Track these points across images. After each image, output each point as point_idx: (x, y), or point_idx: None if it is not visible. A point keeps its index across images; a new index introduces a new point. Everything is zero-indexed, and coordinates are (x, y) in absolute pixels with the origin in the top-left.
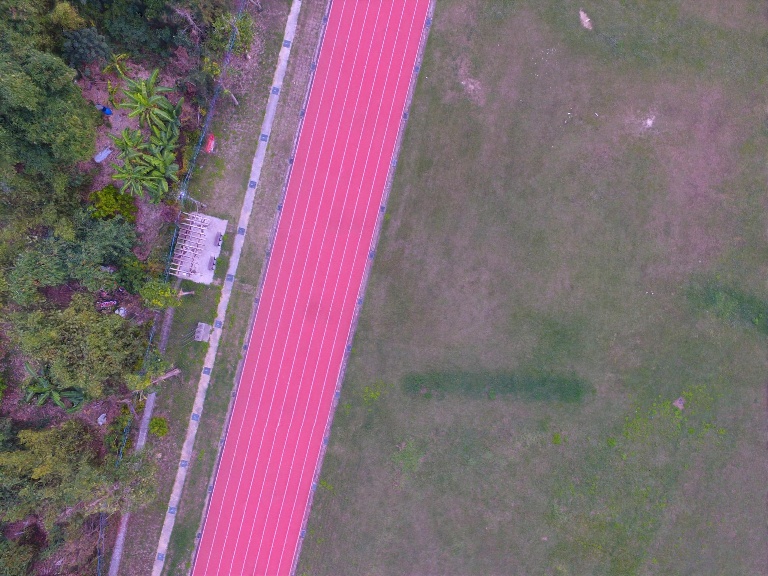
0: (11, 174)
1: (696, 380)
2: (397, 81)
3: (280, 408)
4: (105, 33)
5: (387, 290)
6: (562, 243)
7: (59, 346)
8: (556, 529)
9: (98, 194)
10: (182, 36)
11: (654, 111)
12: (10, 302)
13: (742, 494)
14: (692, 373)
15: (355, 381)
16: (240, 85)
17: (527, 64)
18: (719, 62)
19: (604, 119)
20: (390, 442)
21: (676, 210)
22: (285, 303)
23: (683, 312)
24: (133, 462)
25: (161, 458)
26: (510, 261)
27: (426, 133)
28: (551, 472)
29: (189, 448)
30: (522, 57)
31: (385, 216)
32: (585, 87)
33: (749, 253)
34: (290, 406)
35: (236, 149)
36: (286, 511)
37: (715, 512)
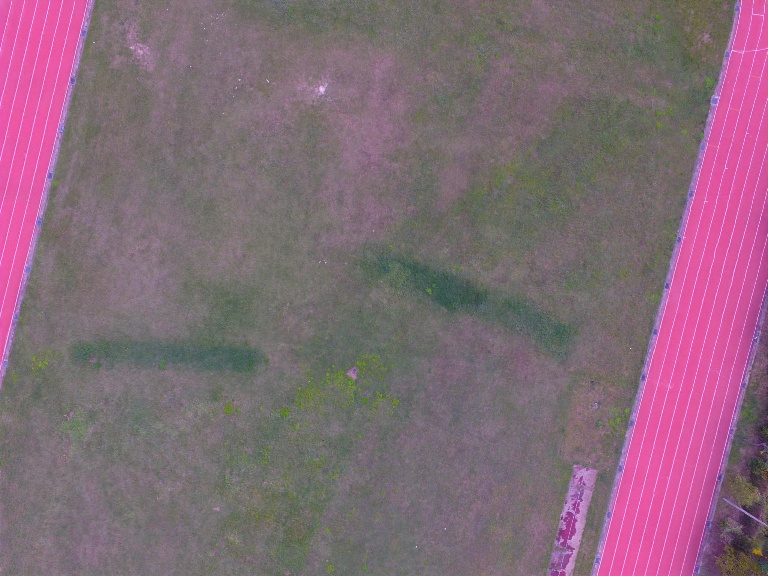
0: None
1: (370, 350)
2: (63, 45)
3: None
4: None
5: (55, 258)
6: (234, 211)
7: None
8: (228, 499)
9: None
10: None
11: (326, 78)
12: None
13: (416, 464)
14: (366, 343)
15: (23, 350)
16: None
17: (196, 29)
18: (392, 29)
19: (275, 86)
20: (58, 412)
21: (349, 179)
22: None
23: (356, 282)
24: None
25: None
26: (181, 229)
27: (94, 99)
28: (223, 442)
29: None
30: (191, 22)
31: (52, 183)
32: (256, 53)
33: (423, 222)
34: None
35: None
36: None
37: (389, 482)
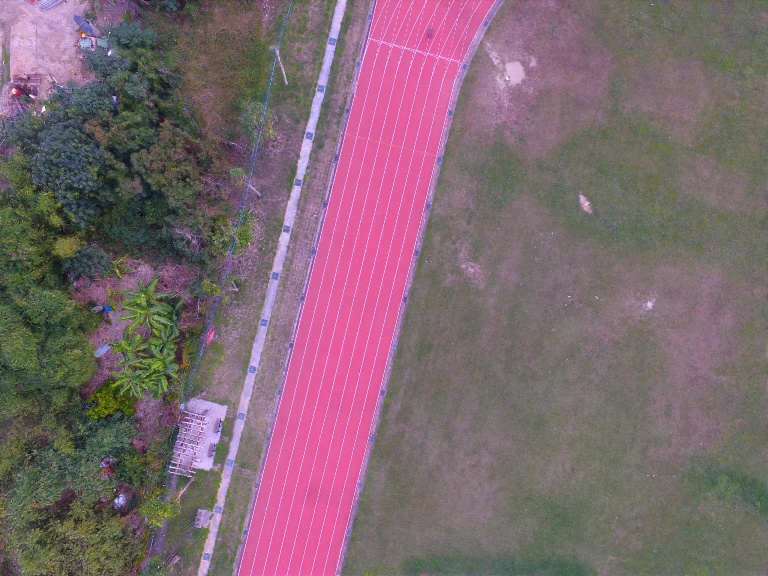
0: (10, 397)
1: (698, 563)
2: (397, 265)
3: None
4: (105, 234)
5: (387, 474)
6: (563, 426)
7: (58, 558)
8: None
9: (97, 396)
10: (182, 246)
11: (654, 294)
12: None
13: None
14: (694, 556)
15: (355, 565)
16: (240, 271)
17: (527, 248)
18: (719, 245)
19: (604, 302)
20: None
21: (677, 392)
22: (285, 488)
23: (684, 495)
24: None
25: None
26: (511, 444)
27: (426, 317)
28: None
29: None
30: (522, 241)
31: (385, 400)
32: (585, 270)
33: (750, 435)
34: None
35: (236, 334)
36: None
37: None
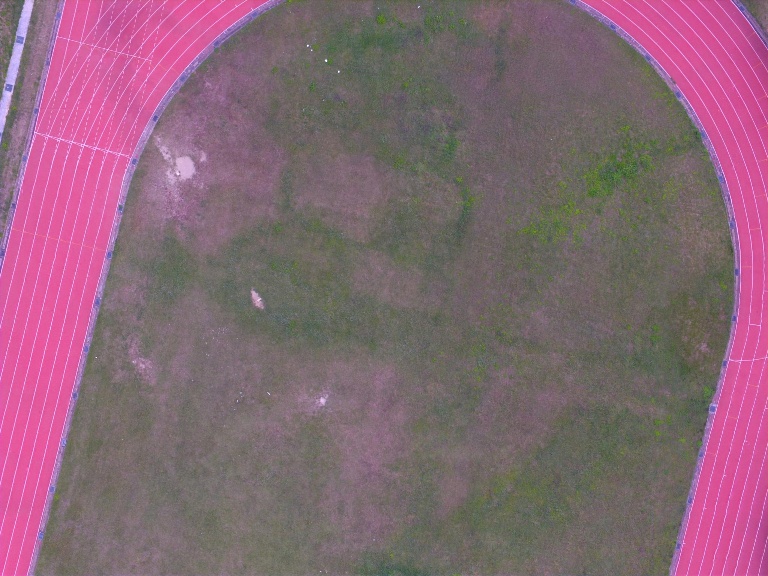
0: None
1: None
2: (66, 361)
3: None
4: None
5: (56, 571)
6: (235, 522)
7: None
8: None
9: None
10: None
11: (327, 390)
12: None
13: None
14: None
15: None
16: None
17: (198, 344)
18: (392, 341)
19: (276, 398)
20: None
21: (350, 488)
22: None
23: None
24: None
25: None
26: (182, 541)
27: (96, 413)
28: None
29: None
30: (193, 337)
31: (54, 497)
32: (257, 366)
33: (423, 531)
34: None
35: None
36: None
37: None
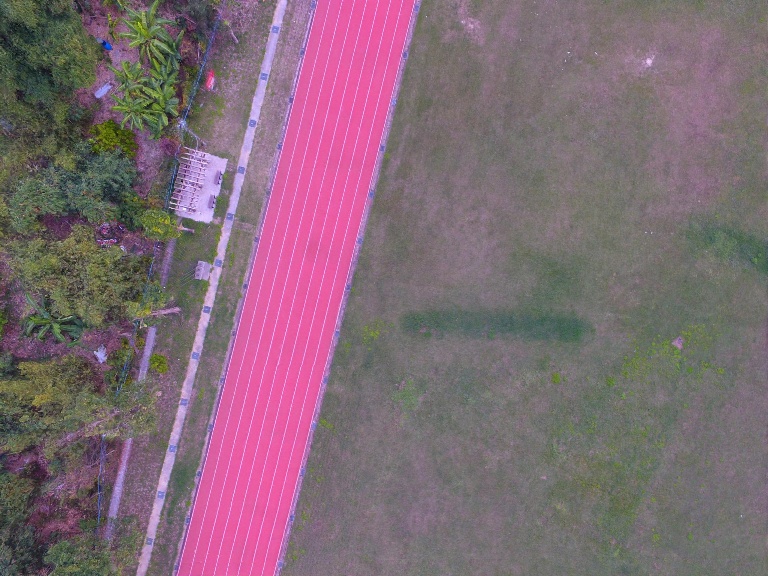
0: (11, 100)
1: (695, 320)
2: (397, 20)
3: (280, 347)
4: None
5: (387, 229)
6: (561, 182)
7: (59, 276)
8: (555, 468)
9: (98, 127)
10: None
11: (654, 50)
12: (10, 231)
13: (741, 433)
14: (691, 313)
15: (355, 320)
16: (240, 23)
17: (527, 3)
18: (719, 1)
19: (604, 58)
20: (390, 381)
21: (675, 150)
22: (285, 242)
23: (682, 252)
24: (133, 391)
25: (161, 396)
26: (510, 200)
27: (426, 72)
28: (550, 411)
29: (189, 386)
30: None
31: (385, 155)
32: (585, 26)
33: (748, 193)
34: (290, 345)
35: (236, 88)
36: (286, 450)
37: (714, 451)
